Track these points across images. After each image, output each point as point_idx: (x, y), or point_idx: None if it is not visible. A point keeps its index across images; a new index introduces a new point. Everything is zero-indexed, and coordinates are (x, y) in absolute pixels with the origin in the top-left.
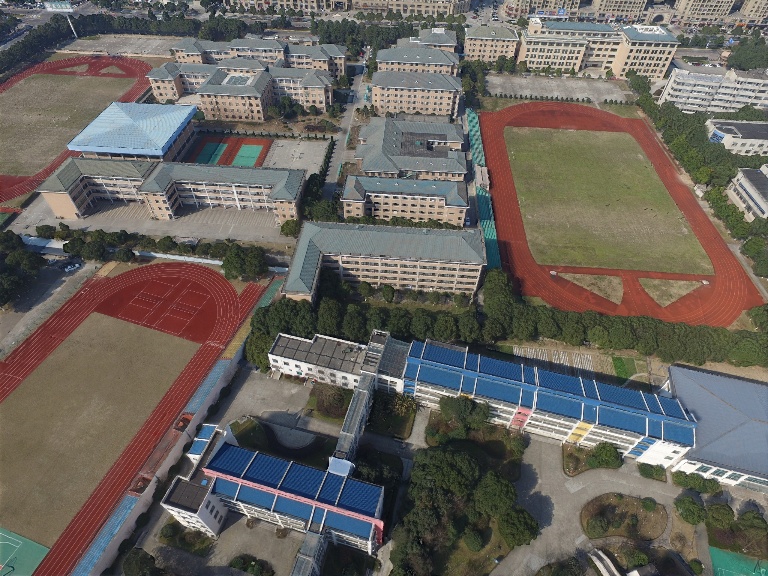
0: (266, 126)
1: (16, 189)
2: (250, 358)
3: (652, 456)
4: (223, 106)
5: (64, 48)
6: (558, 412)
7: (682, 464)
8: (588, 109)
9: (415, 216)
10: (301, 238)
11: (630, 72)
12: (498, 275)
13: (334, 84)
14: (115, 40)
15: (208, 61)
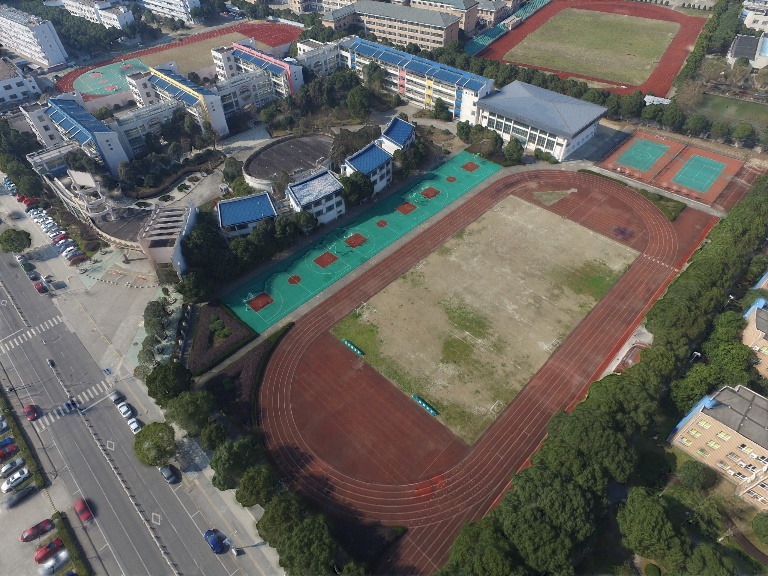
0: None
1: None
2: (291, 50)
3: (466, 113)
4: None
5: None
6: (416, 69)
7: (480, 118)
8: (660, 8)
9: None
10: None
11: None
12: None
13: None
14: None
15: None
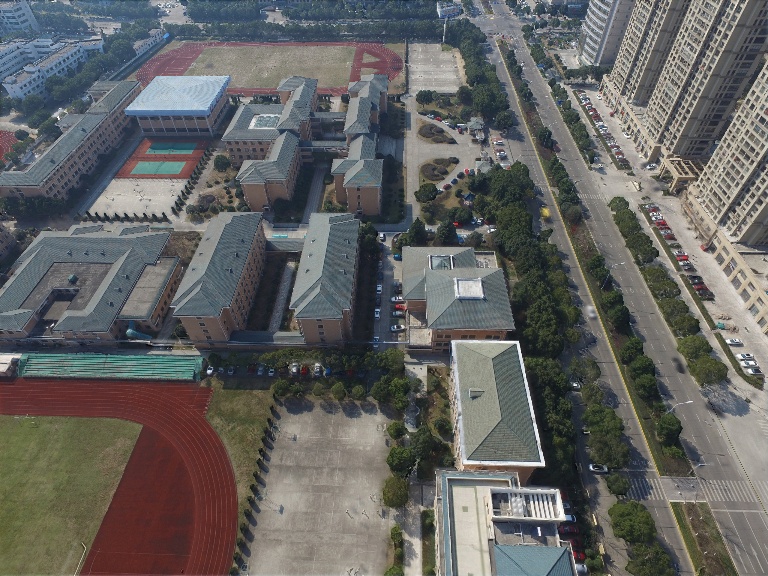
0: None
1: None
2: None
3: None
4: None
5: (416, 44)
6: None
7: None
8: None
9: None
10: None
11: None
12: None
13: None
14: (445, 58)
15: None
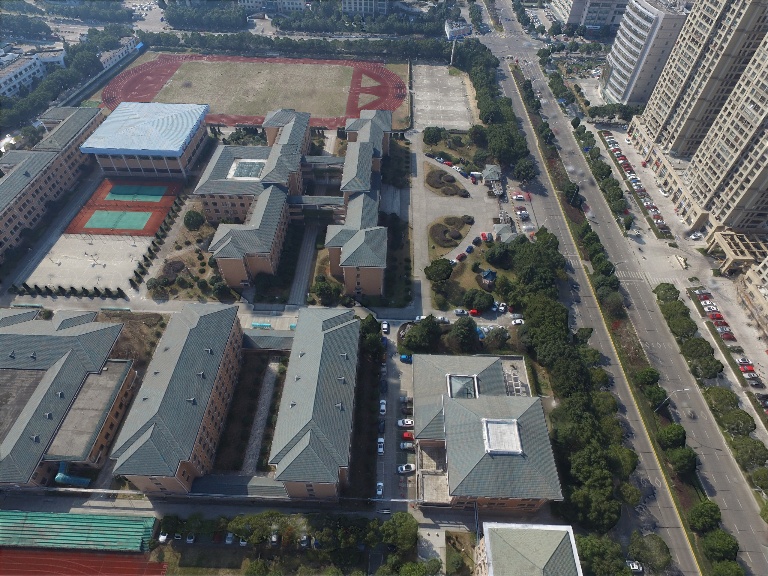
0: None
1: None
2: None
3: None
4: None
5: (421, 65)
6: None
7: None
8: None
9: None
10: None
11: None
12: None
13: None
14: (454, 84)
15: None
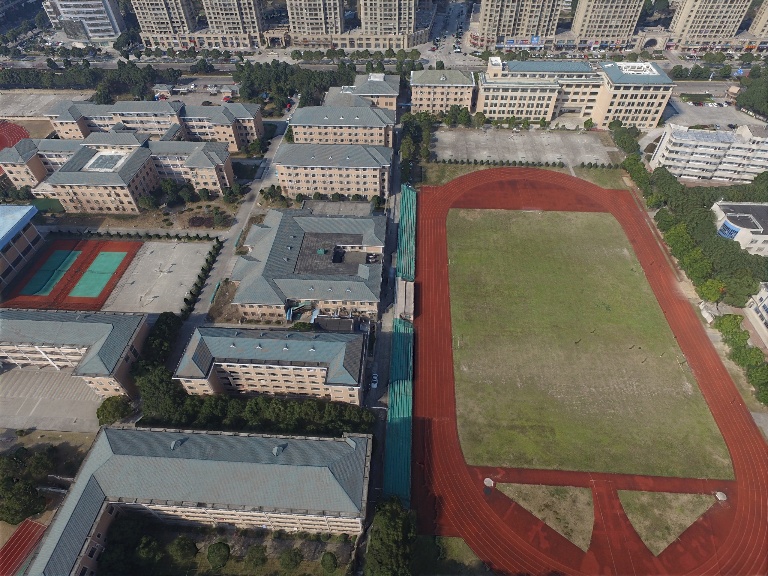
0: (140, 220)
1: None
2: None
3: None
4: (84, 197)
5: None
6: None
7: None
8: (560, 177)
9: (293, 385)
10: (84, 467)
11: (614, 123)
12: (388, 525)
13: (243, 152)
14: (0, 98)
15: (90, 128)
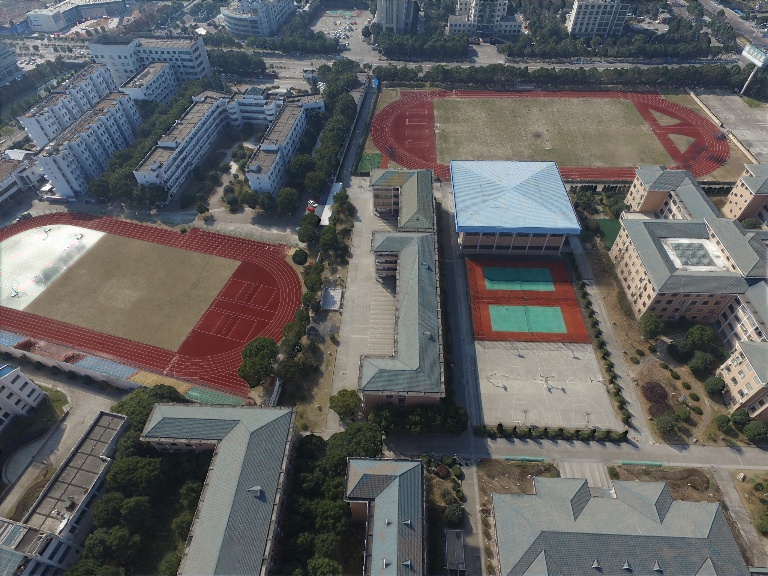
0: (628, 325)
1: (415, 162)
2: None
3: None
4: (628, 258)
5: (706, 96)
6: None
7: None
8: None
9: None
10: (254, 409)
11: None
12: None
13: None
14: (767, 119)
15: (763, 210)
